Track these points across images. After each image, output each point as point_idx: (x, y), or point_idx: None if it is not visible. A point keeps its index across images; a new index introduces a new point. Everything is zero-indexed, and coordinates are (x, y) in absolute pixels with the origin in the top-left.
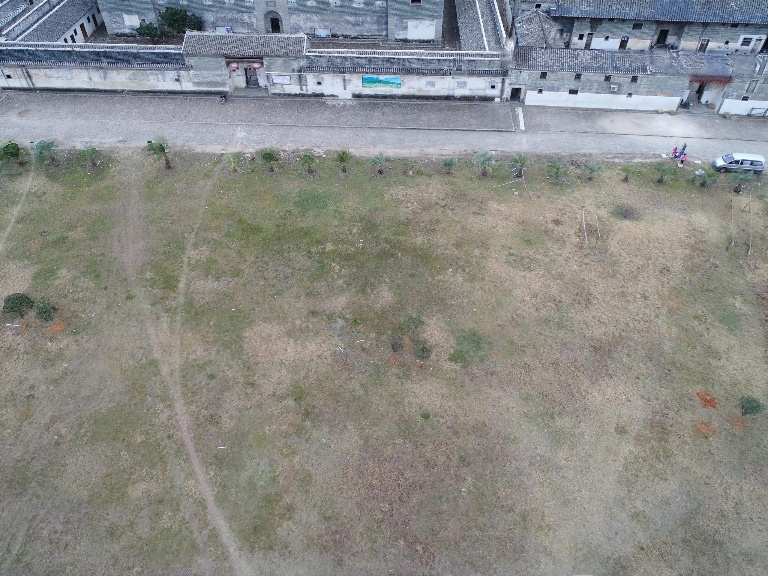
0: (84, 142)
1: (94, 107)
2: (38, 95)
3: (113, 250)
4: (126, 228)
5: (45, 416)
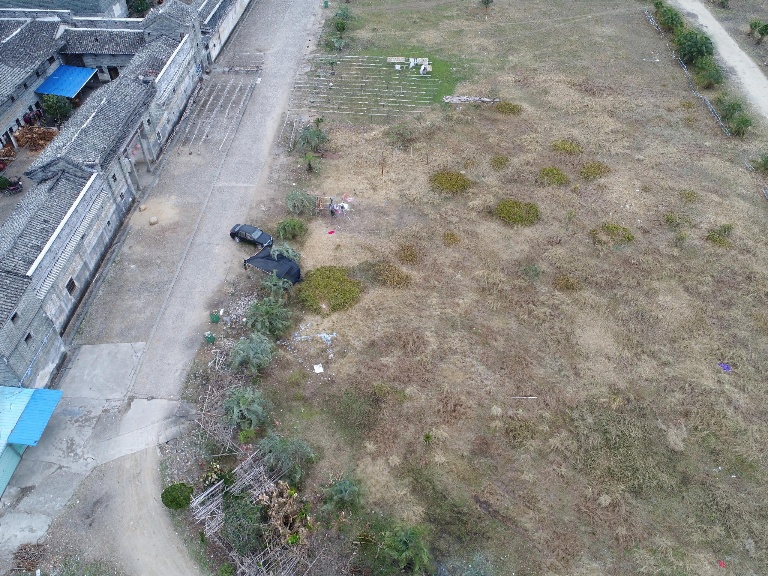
0: (313, 25)
1: (260, 28)
2: (230, 50)
3: (428, 7)
4: (409, 6)
5: (532, 5)
